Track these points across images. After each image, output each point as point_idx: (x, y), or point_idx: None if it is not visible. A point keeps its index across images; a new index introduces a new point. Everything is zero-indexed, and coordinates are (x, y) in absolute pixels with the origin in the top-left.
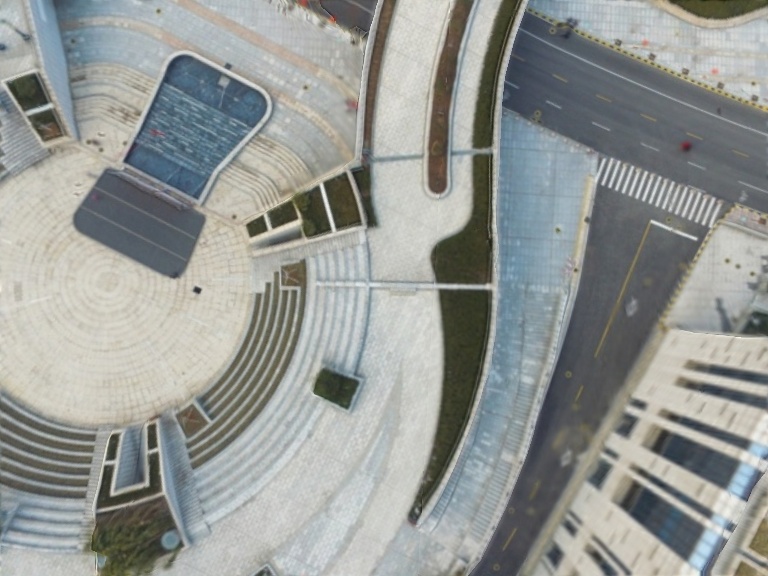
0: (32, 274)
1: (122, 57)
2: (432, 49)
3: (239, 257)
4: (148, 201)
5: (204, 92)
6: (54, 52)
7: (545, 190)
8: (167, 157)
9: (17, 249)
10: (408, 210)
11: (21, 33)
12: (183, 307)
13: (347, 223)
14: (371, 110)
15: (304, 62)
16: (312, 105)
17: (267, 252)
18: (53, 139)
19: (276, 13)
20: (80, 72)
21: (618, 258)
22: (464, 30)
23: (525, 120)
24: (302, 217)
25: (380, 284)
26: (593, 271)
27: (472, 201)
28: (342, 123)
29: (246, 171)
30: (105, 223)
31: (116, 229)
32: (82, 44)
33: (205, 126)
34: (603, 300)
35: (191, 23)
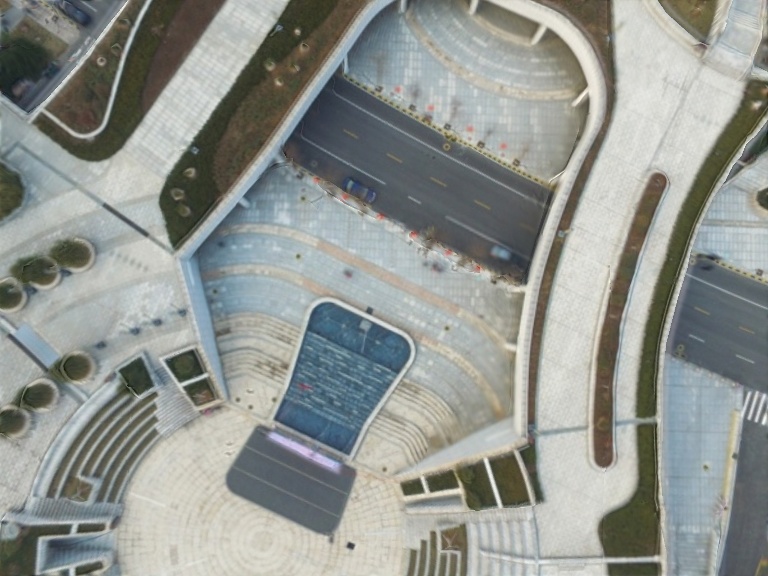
0: (187, 537)
1: (264, 306)
2: (593, 319)
3: (391, 511)
4: (300, 460)
5: (346, 336)
6: (202, 313)
7: (691, 426)
8: (316, 412)
9: (171, 512)
10: (574, 483)
11: (176, 307)
12: (337, 564)
13: (515, 502)
14: (534, 384)
15: (444, 302)
16: (454, 346)
17: (423, 512)
18: (206, 403)
19: (416, 254)
20: (224, 324)
21: (767, 494)
22: (626, 301)
23: (669, 355)
24: (464, 487)
25: (549, 561)
26: (743, 508)
27: (637, 472)
28: (485, 363)
29: (393, 420)
30: (258, 483)
31: (269, 489)
32: (224, 294)
33: (350, 375)
34: (754, 538)
35: (331, 267)
